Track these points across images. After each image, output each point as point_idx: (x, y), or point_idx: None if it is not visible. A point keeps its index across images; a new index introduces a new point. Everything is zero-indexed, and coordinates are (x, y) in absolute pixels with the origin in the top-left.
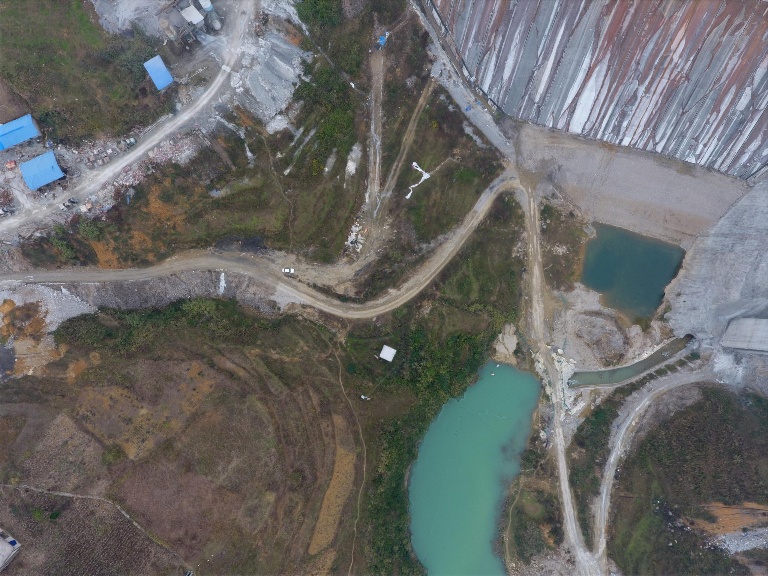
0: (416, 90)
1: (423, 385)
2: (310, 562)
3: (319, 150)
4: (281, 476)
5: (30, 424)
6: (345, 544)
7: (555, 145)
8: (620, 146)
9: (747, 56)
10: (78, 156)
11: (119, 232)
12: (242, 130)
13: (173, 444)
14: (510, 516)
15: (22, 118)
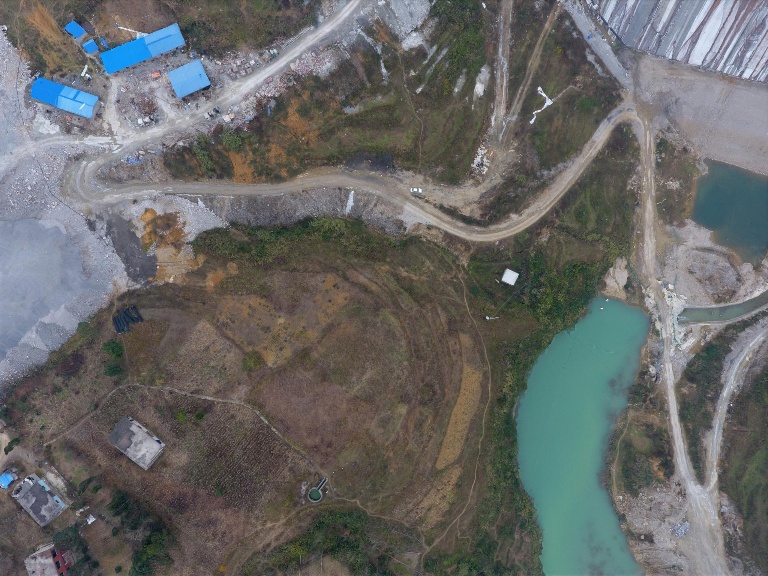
0: (543, 14)
1: (542, 311)
2: (437, 476)
3: (451, 69)
4: (413, 389)
5: (173, 329)
6: (470, 461)
7: (674, 77)
8: (741, 78)
9: None
10: (221, 67)
11: (258, 144)
12: (379, 45)
13: (309, 353)
14: (618, 449)
15: (169, 27)
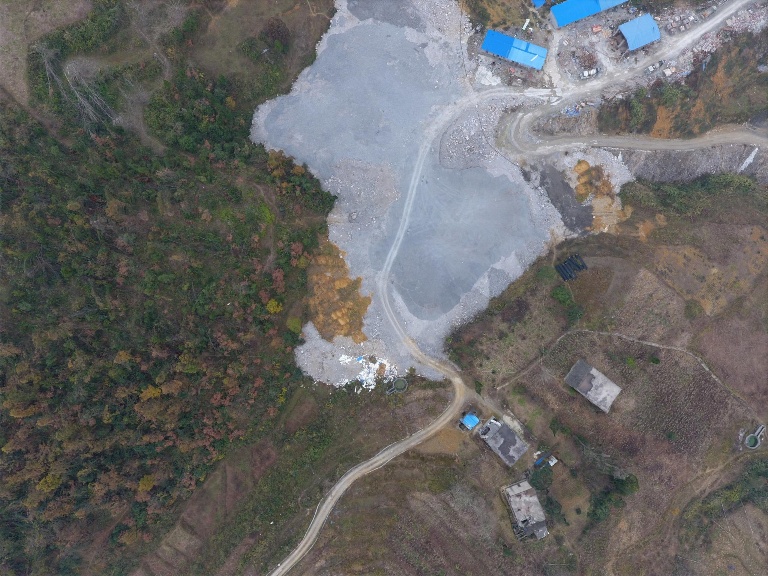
0: None
1: None
2: None
3: None
4: None
5: (617, 276)
6: None
7: None
8: None
9: None
10: (658, 23)
11: (689, 98)
12: None
13: (743, 303)
14: None
15: None
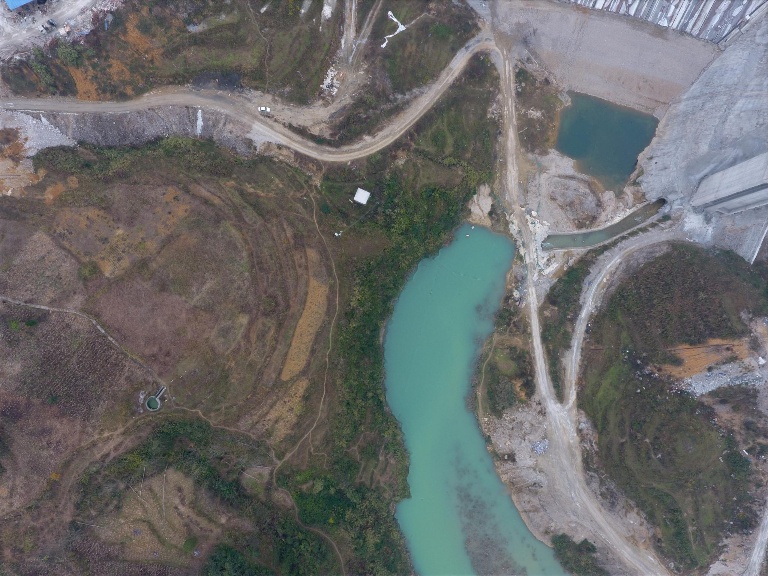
0: None
1: (397, 231)
2: (282, 387)
3: None
4: (254, 299)
5: (8, 239)
6: (317, 373)
7: (530, 7)
8: (594, 9)
9: None
10: None
11: (97, 58)
12: None
13: (148, 264)
14: (483, 372)
15: None
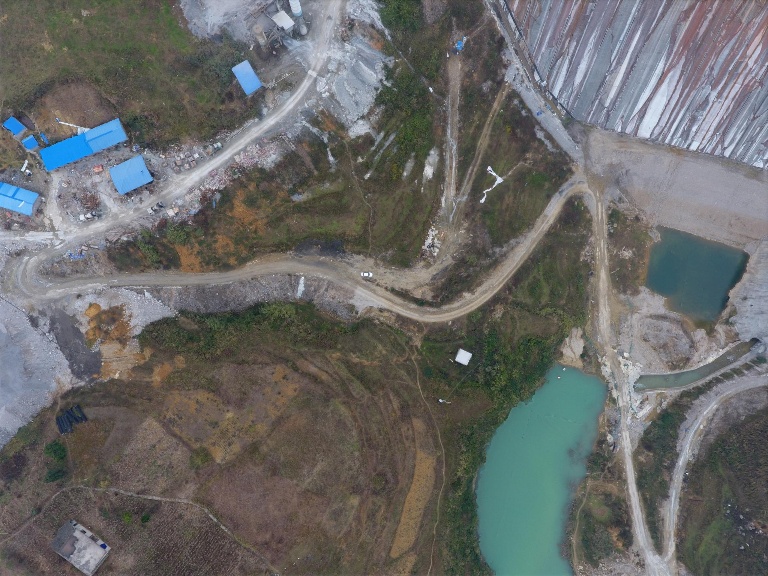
0: (491, 95)
1: (497, 389)
2: (392, 565)
3: (399, 154)
4: (365, 480)
5: (118, 428)
6: (425, 547)
7: (623, 149)
8: (688, 151)
9: None
10: (164, 160)
11: (204, 236)
12: (325, 135)
13: (259, 448)
14: (577, 519)
15: (111, 122)
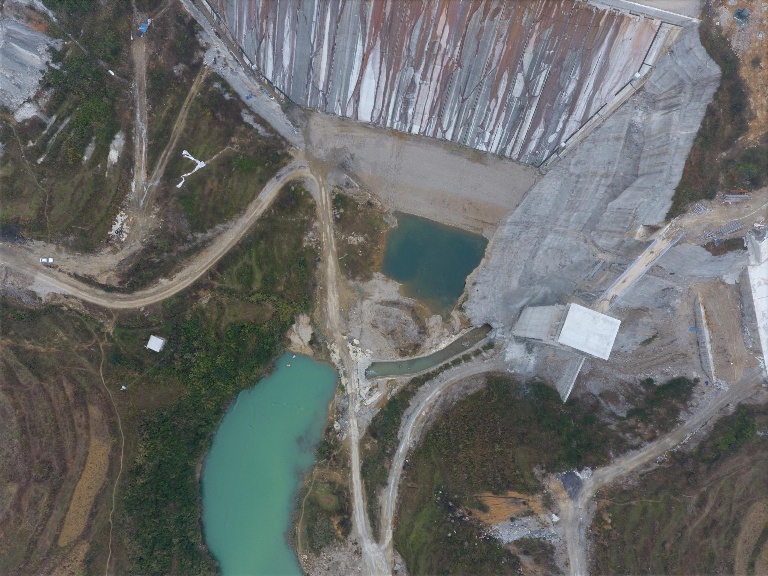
0: (186, 78)
1: (196, 375)
2: (59, 554)
3: (74, 138)
4: (24, 467)
5: None
6: (99, 536)
7: (344, 133)
8: (410, 134)
9: (511, 41)
10: None
11: None
12: None
13: None
14: (303, 508)
15: None
